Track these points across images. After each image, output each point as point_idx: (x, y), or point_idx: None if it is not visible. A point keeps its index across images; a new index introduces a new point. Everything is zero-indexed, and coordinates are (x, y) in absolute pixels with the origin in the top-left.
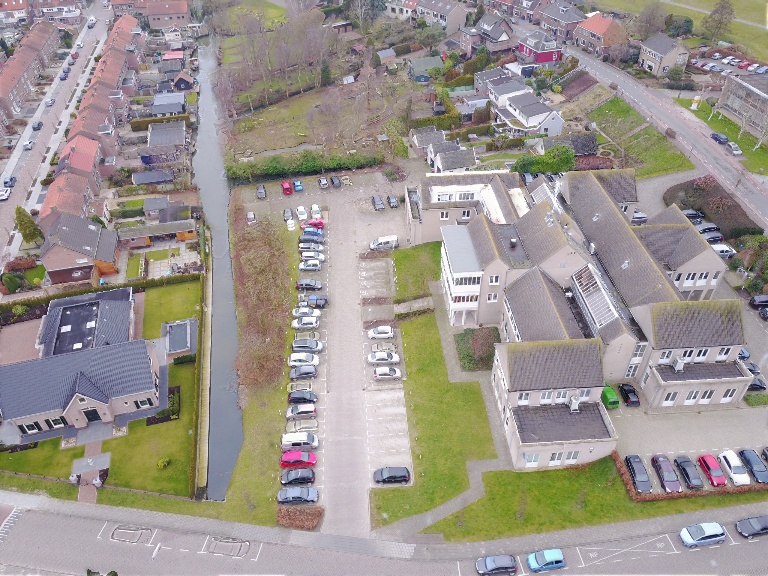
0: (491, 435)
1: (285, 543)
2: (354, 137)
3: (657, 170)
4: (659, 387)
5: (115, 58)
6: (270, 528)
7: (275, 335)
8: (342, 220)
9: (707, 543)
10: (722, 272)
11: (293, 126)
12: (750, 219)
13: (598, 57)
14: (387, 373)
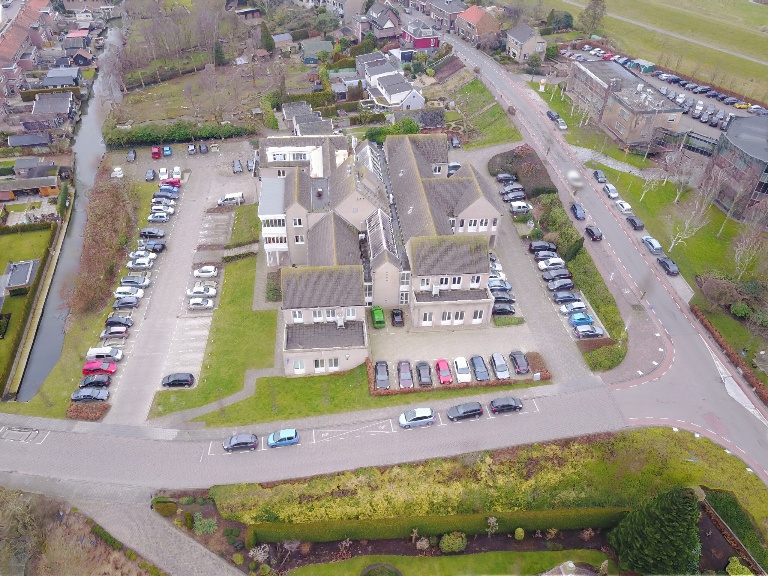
0: (274, 350)
1: (69, 431)
2: (234, 111)
3: (490, 141)
4: (414, 307)
5: (16, 34)
6: (59, 420)
7: (108, 273)
8: (200, 181)
9: (419, 424)
10: (499, 219)
11: (179, 100)
12: (551, 181)
13: (473, 45)
14: (199, 303)
